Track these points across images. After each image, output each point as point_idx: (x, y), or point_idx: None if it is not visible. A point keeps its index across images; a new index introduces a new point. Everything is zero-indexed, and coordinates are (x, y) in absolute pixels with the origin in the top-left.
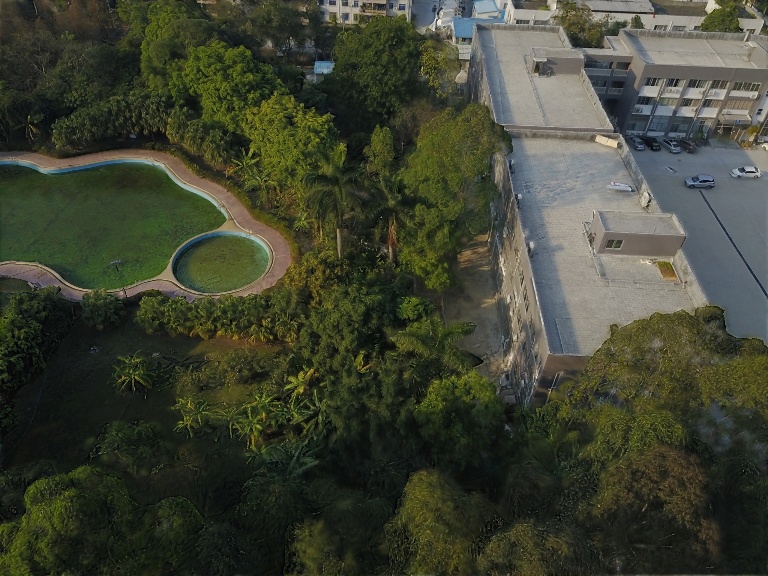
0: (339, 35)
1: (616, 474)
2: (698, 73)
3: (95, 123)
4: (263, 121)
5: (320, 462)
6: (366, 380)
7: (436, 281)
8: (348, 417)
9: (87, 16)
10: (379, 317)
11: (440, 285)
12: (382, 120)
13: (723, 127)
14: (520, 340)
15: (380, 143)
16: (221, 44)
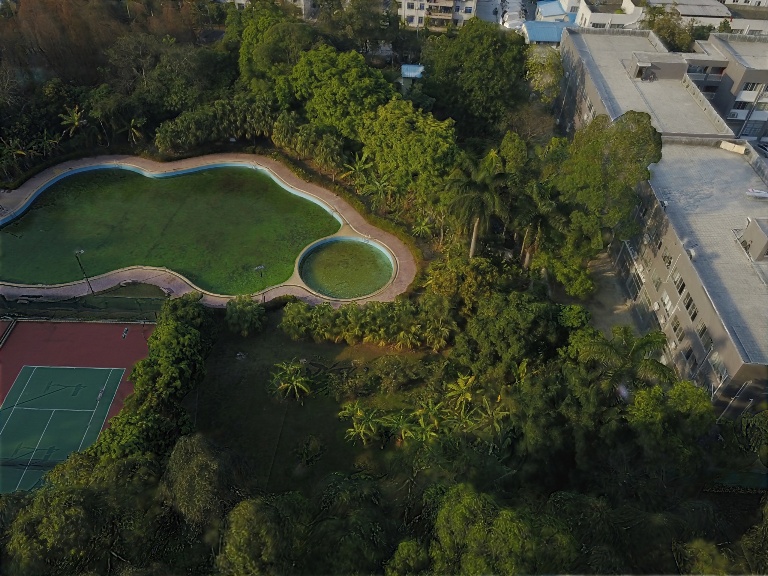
0: (429, 39)
1: None
2: None
3: (200, 127)
4: (384, 126)
5: (519, 471)
6: (555, 389)
7: (579, 288)
8: (546, 426)
9: (181, 19)
10: (545, 325)
11: (582, 292)
12: (486, 125)
13: None
14: (680, 348)
15: (515, 149)
16: (329, 48)
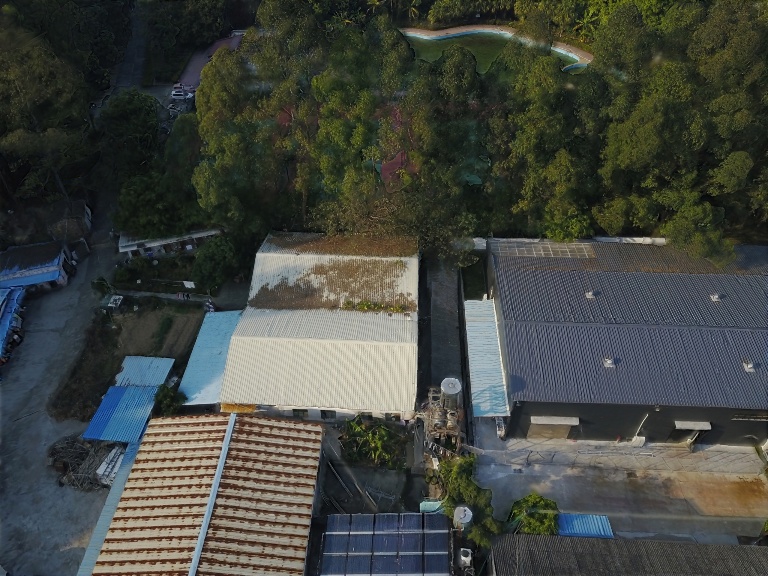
0: None
1: None
2: None
3: (462, 3)
4: None
5: None
6: None
7: None
8: None
9: None
10: None
11: None
12: None
13: None
14: None
15: None
16: None
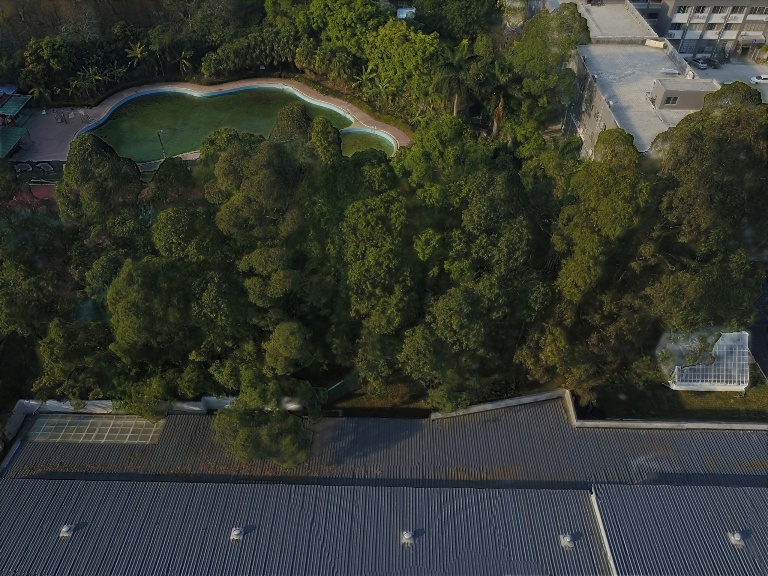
0: None
1: (712, 128)
2: (721, 0)
3: (237, 55)
4: (384, 40)
5: None
6: None
7: (534, 144)
8: None
9: None
10: None
11: None
12: None
13: (742, 47)
14: None
15: (484, 46)
16: None
